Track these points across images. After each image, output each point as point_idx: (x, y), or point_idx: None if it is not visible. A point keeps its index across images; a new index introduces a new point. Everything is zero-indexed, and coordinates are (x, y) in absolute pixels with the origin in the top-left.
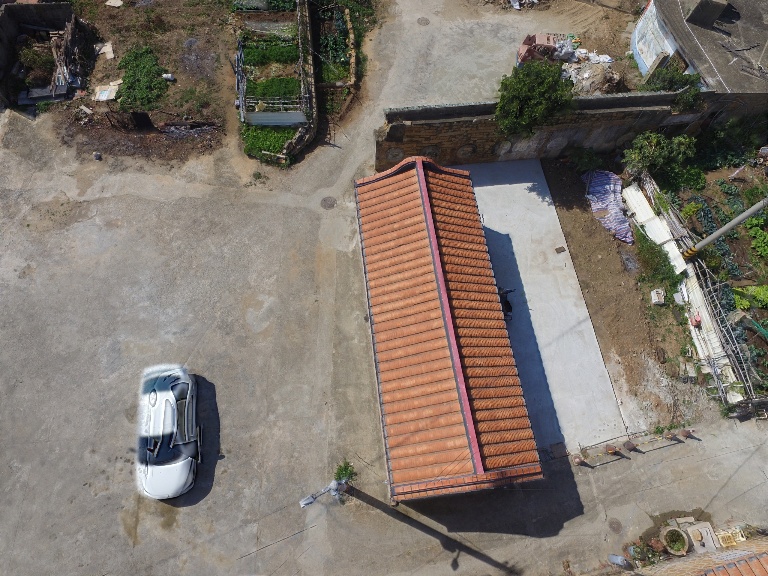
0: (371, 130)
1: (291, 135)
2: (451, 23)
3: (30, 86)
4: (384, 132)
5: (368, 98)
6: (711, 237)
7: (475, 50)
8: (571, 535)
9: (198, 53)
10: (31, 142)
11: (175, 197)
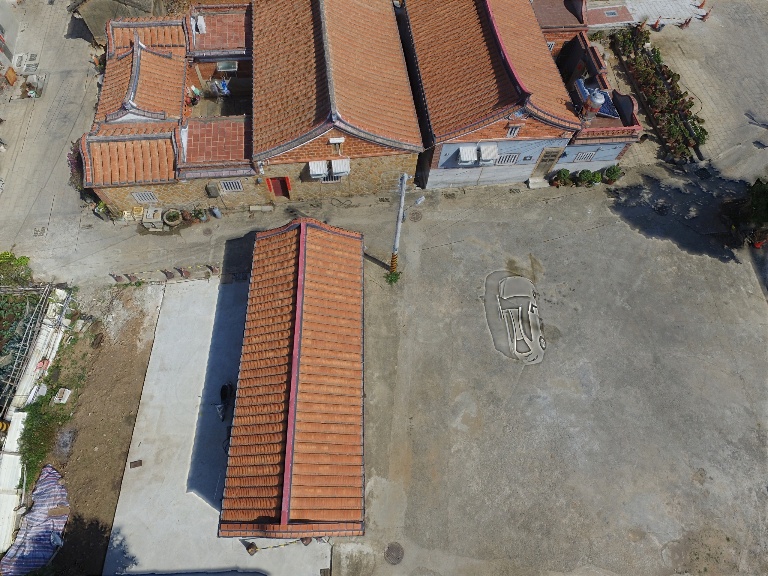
0: None
1: None
2: None
3: None
4: None
5: None
6: None
7: None
8: (241, 230)
9: None
10: None
11: (579, 572)
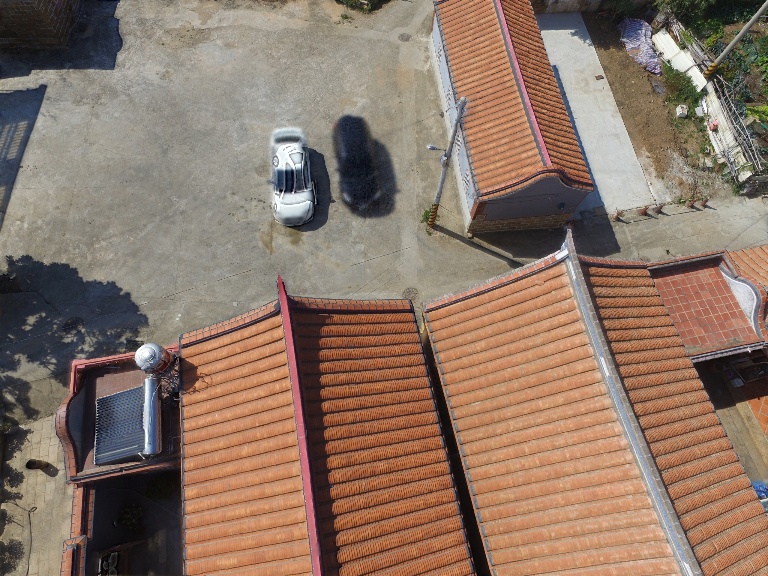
0: None
1: None
2: None
3: None
4: None
5: None
6: (728, 47)
7: None
8: None
9: None
10: None
11: (279, 28)
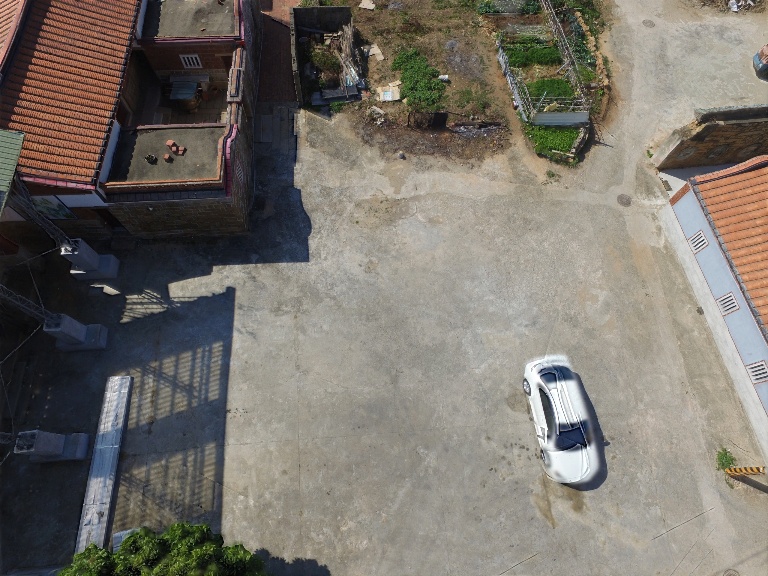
0: (634, 130)
1: (575, 135)
2: (675, 25)
3: (323, 87)
4: (689, 132)
5: (621, 98)
6: None
7: (707, 52)
8: None
9: (462, 55)
10: (335, 141)
11: (485, 195)
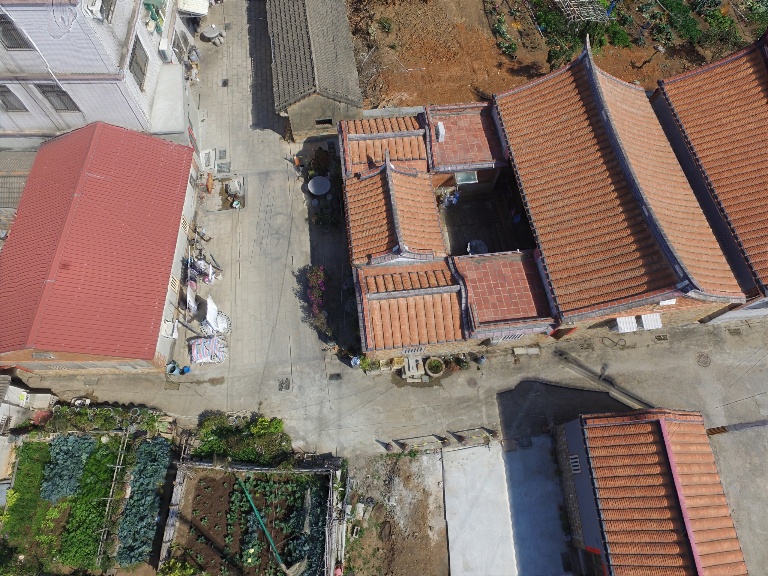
0: None
1: None
2: None
3: None
4: None
5: None
6: None
7: None
8: (510, 380)
9: None
10: None
11: None
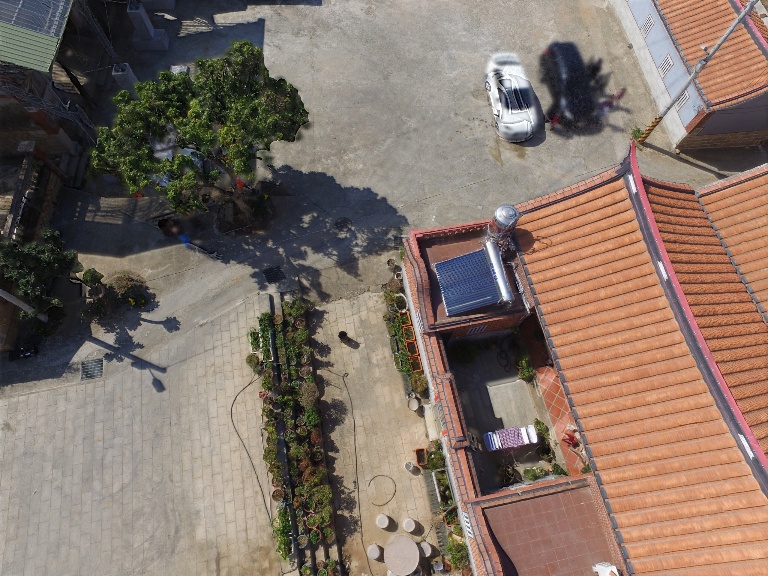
0: None
1: None
2: None
3: None
4: None
5: None
6: None
7: None
8: None
9: None
10: None
11: None
